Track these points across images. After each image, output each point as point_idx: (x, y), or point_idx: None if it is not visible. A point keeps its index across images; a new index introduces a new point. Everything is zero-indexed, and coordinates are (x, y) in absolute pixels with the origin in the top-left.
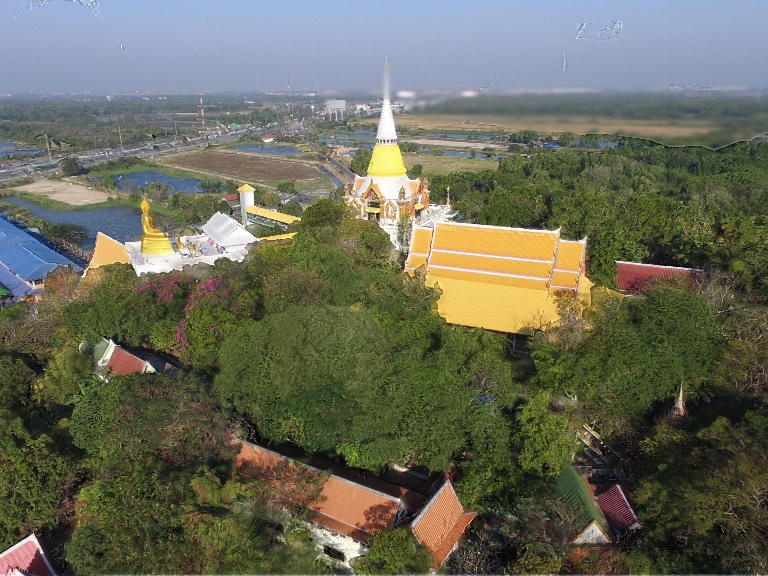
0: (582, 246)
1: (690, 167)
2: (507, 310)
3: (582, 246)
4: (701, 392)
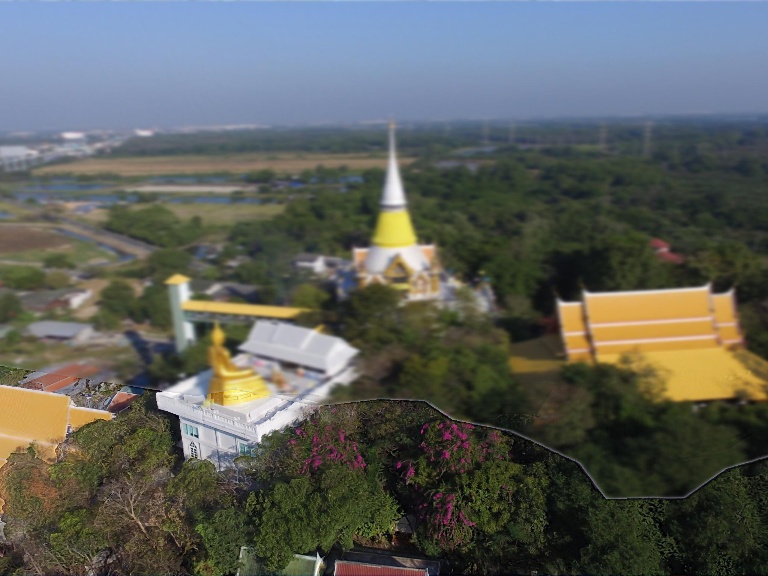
0: None
1: None
2: None
3: None
4: None
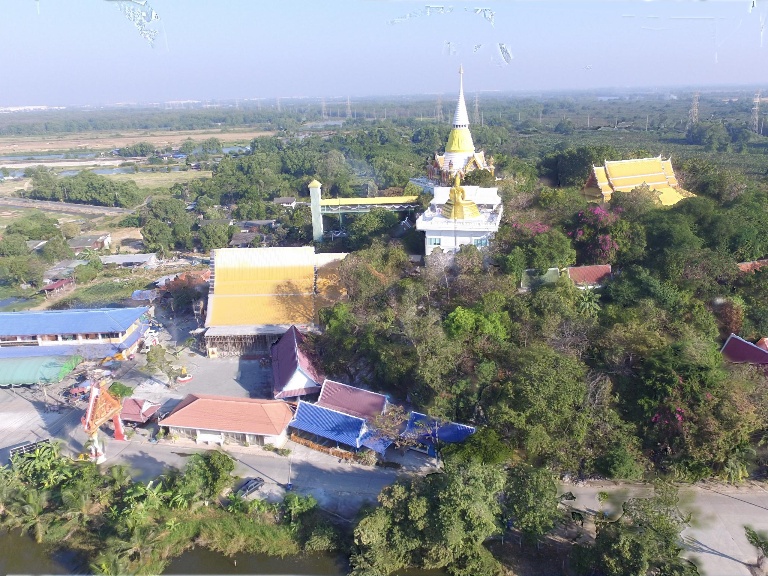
0: (670, 163)
1: None
2: (668, 200)
3: (670, 163)
4: None
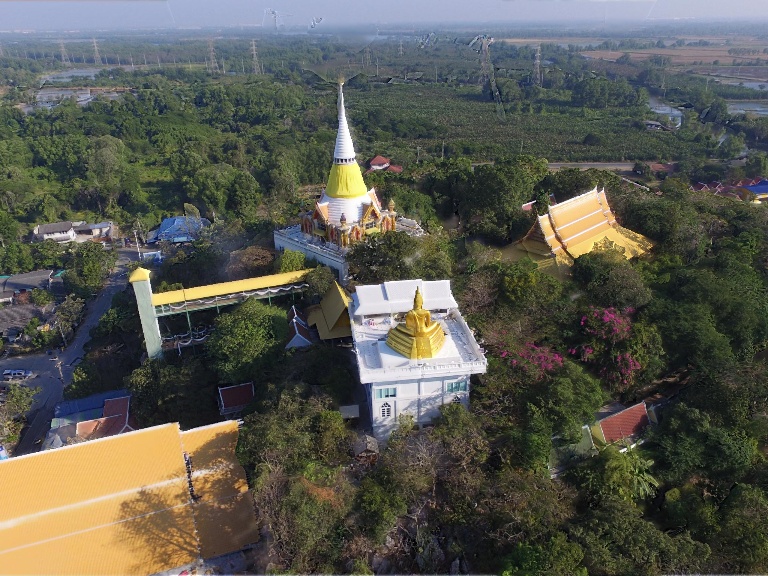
0: None
1: (113, 134)
2: None
3: None
4: (708, 240)
